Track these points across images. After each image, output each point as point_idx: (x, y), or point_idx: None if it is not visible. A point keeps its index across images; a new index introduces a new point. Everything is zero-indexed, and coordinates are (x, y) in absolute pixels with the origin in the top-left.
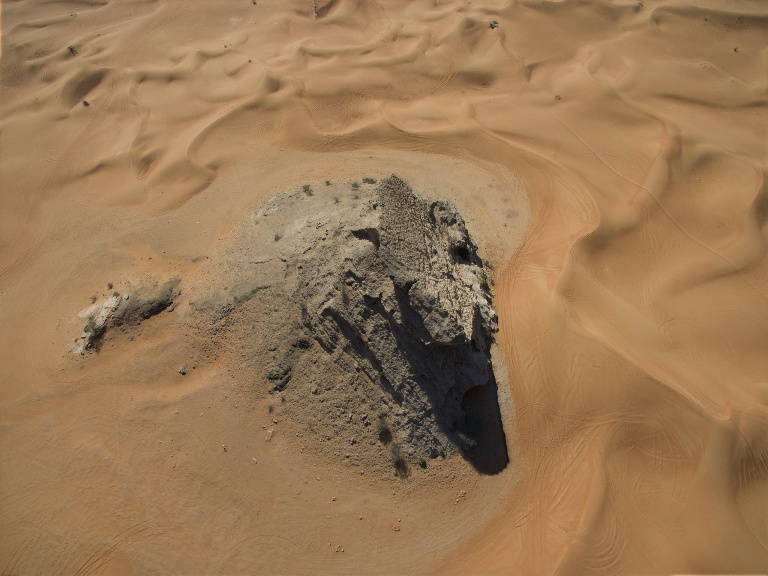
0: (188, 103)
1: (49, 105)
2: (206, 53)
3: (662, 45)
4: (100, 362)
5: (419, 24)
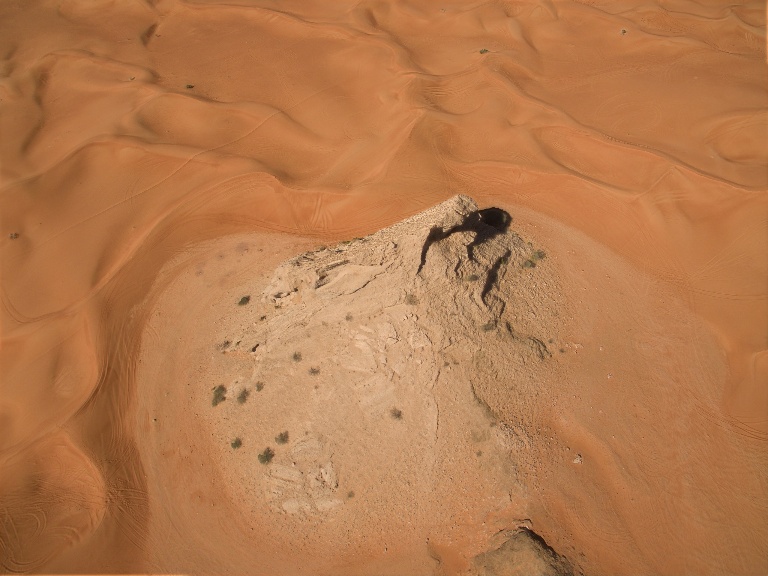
0: None
1: None
2: None
3: None
4: None
5: None
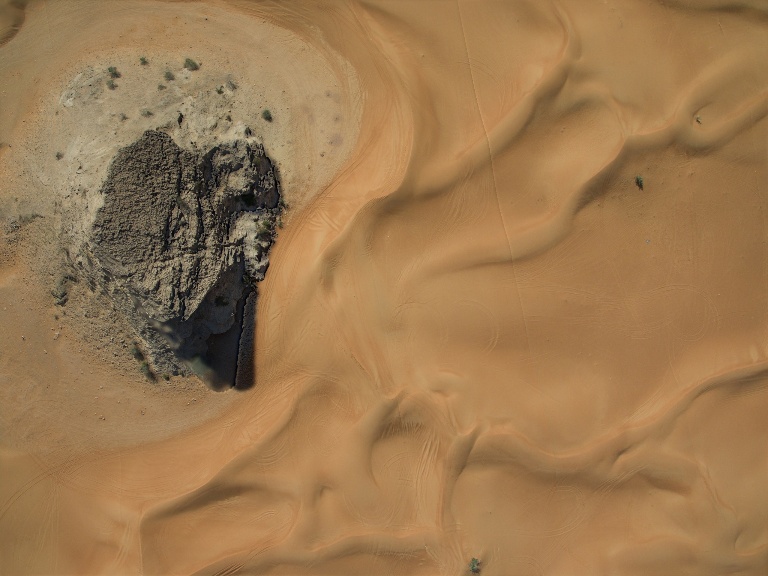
0: None
1: None
2: None
3: None
4: None
5: None
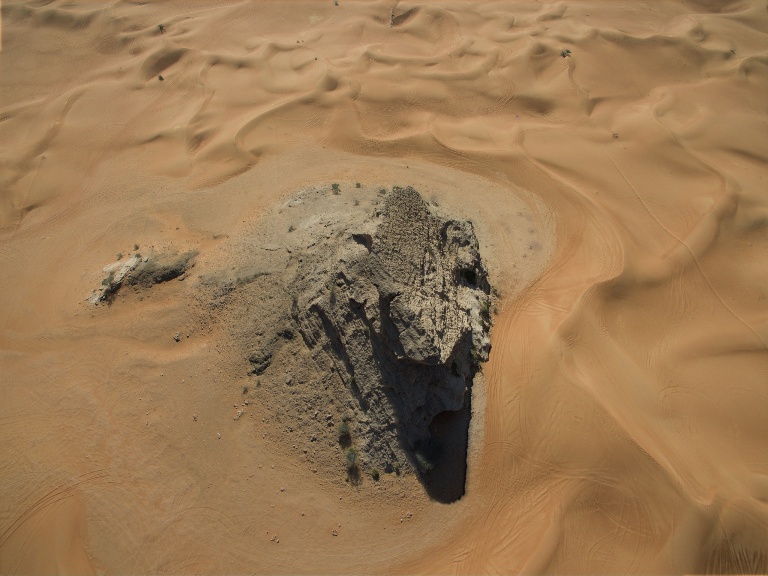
0: (250, 90)
1: (130, 75)
2: (278, 46)
3: (746, 97)
4: (109, 315)
5: (490, 43)
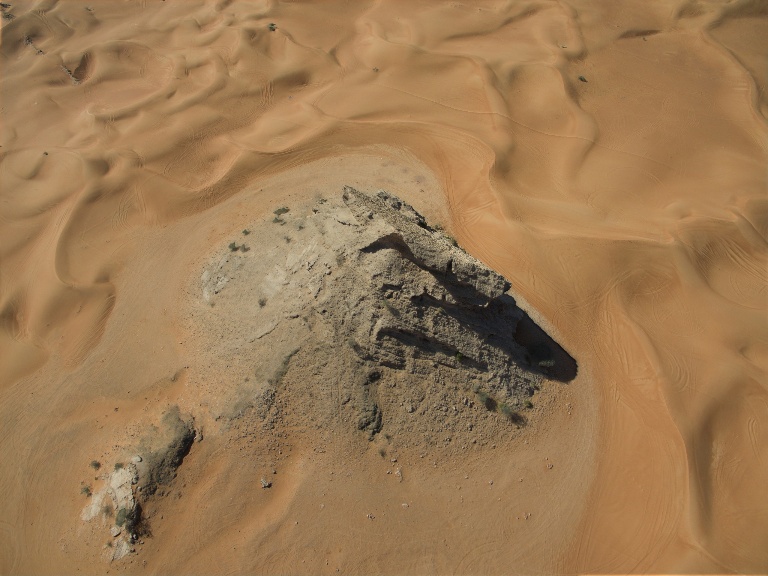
0: (3, 230)
1: None
2: None
3: None
4: (162, 544)
5: (199, 50)
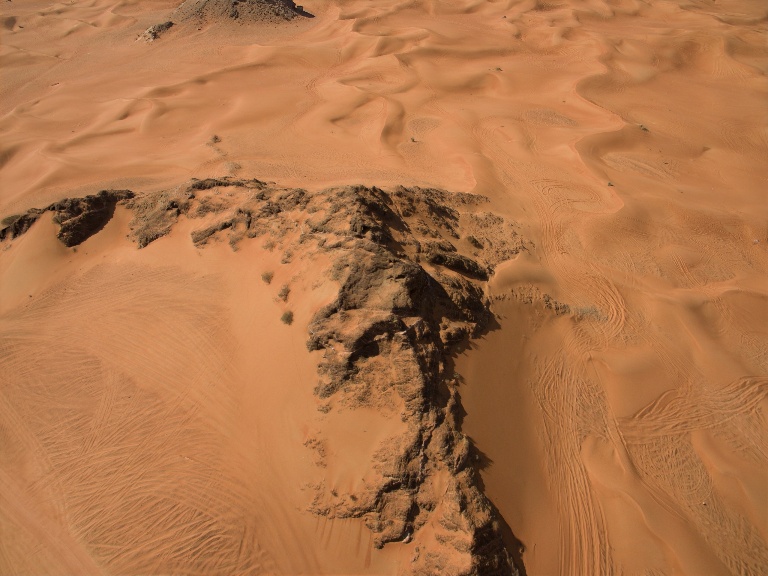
0: None
1: None
2: None
3: None
4: (164, 39)
5: None
